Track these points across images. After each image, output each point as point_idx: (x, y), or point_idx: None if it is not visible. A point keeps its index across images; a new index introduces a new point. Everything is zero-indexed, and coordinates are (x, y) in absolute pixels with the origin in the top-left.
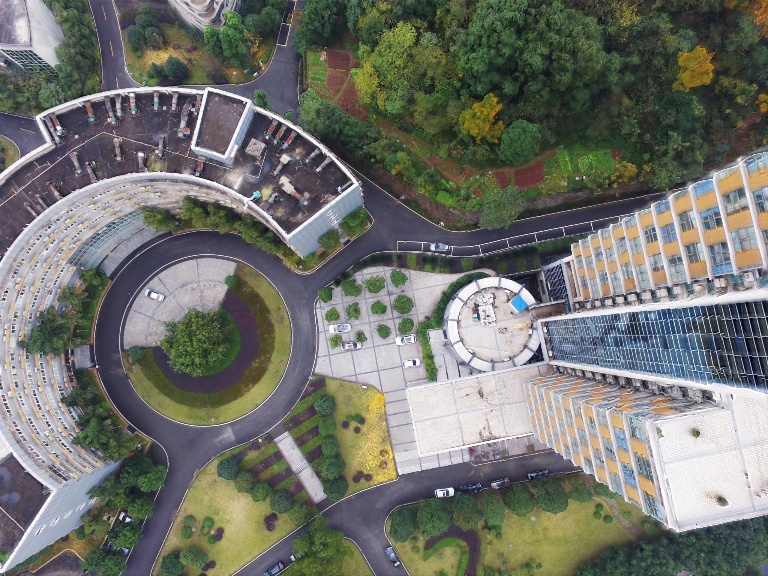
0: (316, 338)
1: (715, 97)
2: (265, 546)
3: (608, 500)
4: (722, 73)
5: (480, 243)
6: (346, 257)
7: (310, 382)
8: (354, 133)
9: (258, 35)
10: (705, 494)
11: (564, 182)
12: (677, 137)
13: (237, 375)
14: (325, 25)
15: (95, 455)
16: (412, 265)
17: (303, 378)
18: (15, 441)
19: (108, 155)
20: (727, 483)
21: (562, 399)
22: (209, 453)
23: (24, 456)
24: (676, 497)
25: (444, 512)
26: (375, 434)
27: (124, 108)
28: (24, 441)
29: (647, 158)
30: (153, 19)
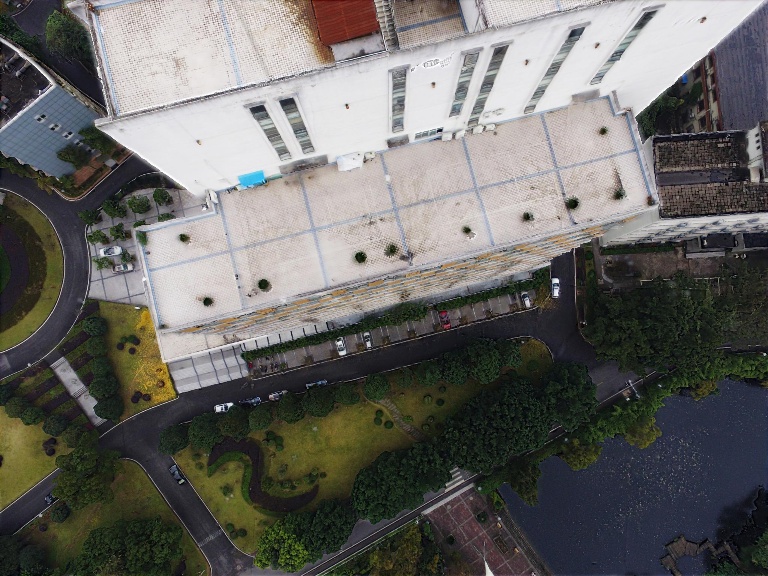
0: (88, 263)
1: None
2: (46, 471)
3: (388, 406)
4: None
5: None
6: (115, 181)
7: (83, 306)
8: None
9: None
10: (194, 297)
11: None
12: None
13: (8, 303)
14: None
15: None
16: None
17: (77, 303)
18: None
19: None
20: (217, 285)
21: None
22: None
23: None
24: (165, 301)
25: (211, 423)
26: (150, 354)
27: None
28: None
29: None
30: None
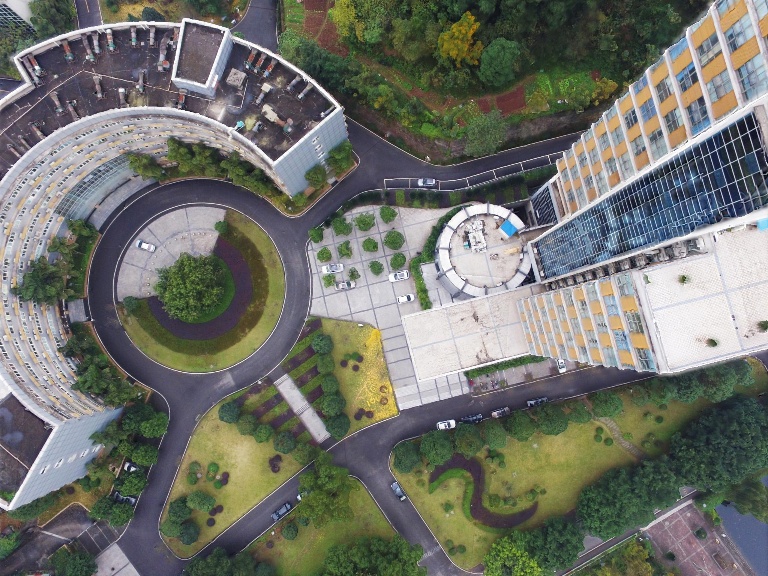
0: (310, 280)
1: (690, 9)
2: (271, 488)
3: (608, 423)
4: None
5: (467, 176)
6: (335, 198)
7: (306, 323)
8: (335, 68)
9: None
10: (694, 337)
11: (546, 100)
12: (655, 49)
13: (233, 320)
14: None
15: (95, 401)
16: (401, 202)
17: (299, 320)
18: (13, 381)
19: (89, 93)
20: (715, 326)
21: (554, 296)
22: (210, 399)
23: (23, 395)
24: (666, 342)
25: (446, 441)
26: (374, 371)
27: (102, 45)
28: (23, 382)
29: (627, 75)
30: None
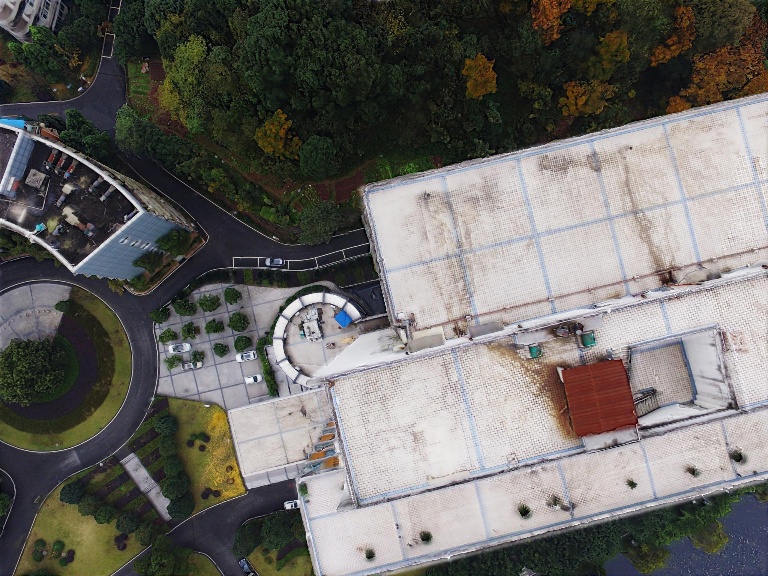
0: (157, 359)
1: (526, 100)
2: (118, 565)
3: None
4: (522, 77)
5: (316, 256)
6: (182, 276)
7: (152, 403)
8: (167, 151)
9: (77, 48)
10: (355, 546)
11: None
12: (484, 144)
13: (77, 400)
14: (135, 37)
15: None
16: (249, 281)
17: (146, 399)
18: None
19: None
20: (377, 534)
21: None
22: (55, 478)
23: None
24: (326, 551)
25: (285, 526)
26: (220, 451)
27: None
28: None
29: None
30: None
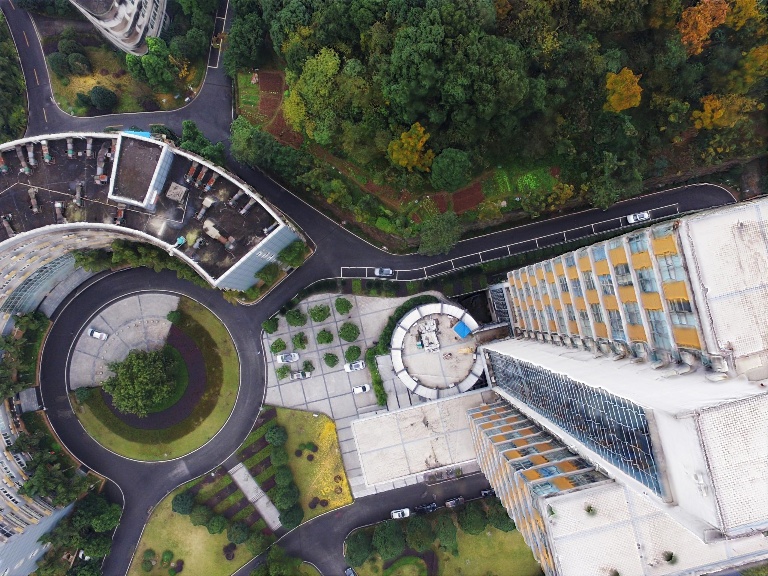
0: (264, 369)
1: (652, 112)
2: (226, 574)
3: None
4: (655, 90)
5: (425, 266)
6: (290, 286)
7: (261, 413)
8: (287, 163)
9: (186, 59)
10: (597, 566)
11: (499, 209)
12: (613, 156)
13: (187, 410)
14: (252, 48)
15: (44, 502)
16: (357, 291)
17: (254, 409)
18: None
19: (24, 206)
20: (619, 554)
21: (489, 443)
22: (164, 488)
23: None
24: (569, 571)
25: (398, 535)
26: (328, 461)
27: (37, 156)
28: None
29: (585, 177)
30: (77, 44)
